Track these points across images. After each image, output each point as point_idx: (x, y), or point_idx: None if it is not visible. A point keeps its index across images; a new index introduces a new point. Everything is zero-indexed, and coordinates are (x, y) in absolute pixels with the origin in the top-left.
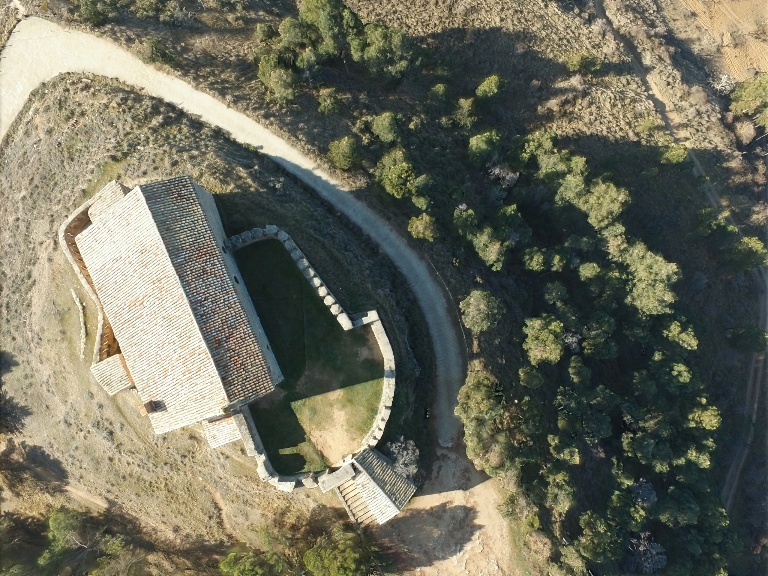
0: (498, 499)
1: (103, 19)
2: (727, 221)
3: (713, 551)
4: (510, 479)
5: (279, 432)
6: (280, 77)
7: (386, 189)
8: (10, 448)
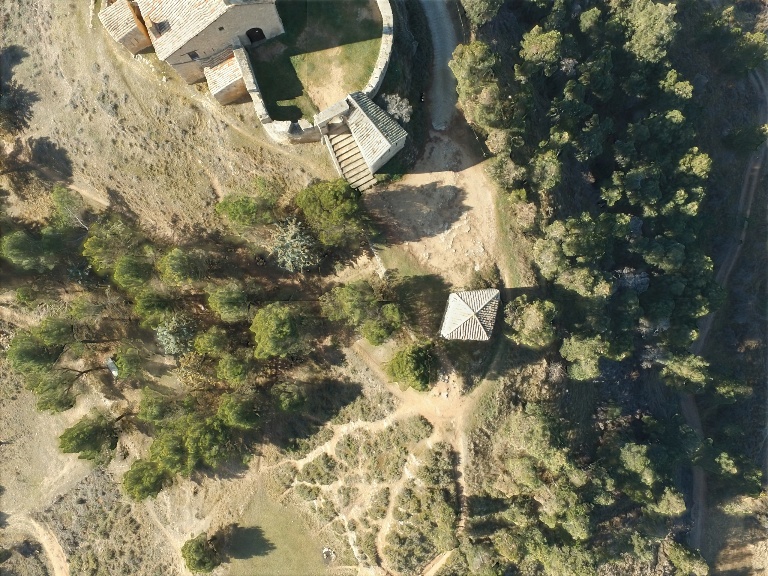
0: (487, 182)
1: None
2: None
3: (696, 294)
4: (499, 136)
5: (278, 85)
6: None
7: None
8: (17, 149)
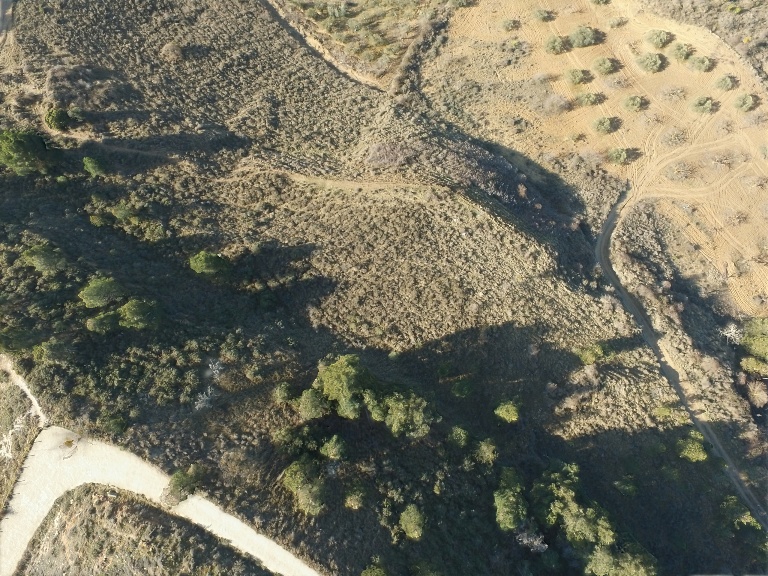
0: None
1: (125, 426)
2: (747, 496)
3: None
4: None
5: None
6: None
7: None
8: None
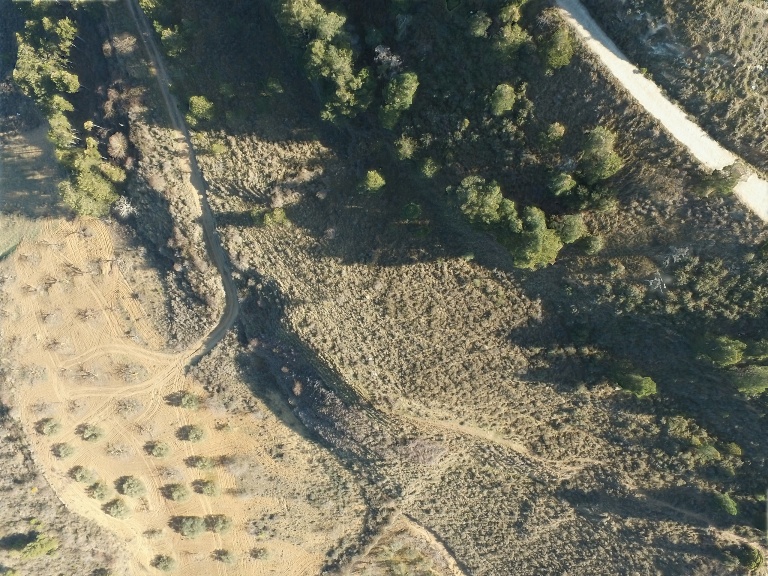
0: None
1: None
2: (154, 52)
3: None
4: None
5: None
6: None
7: None
8: None
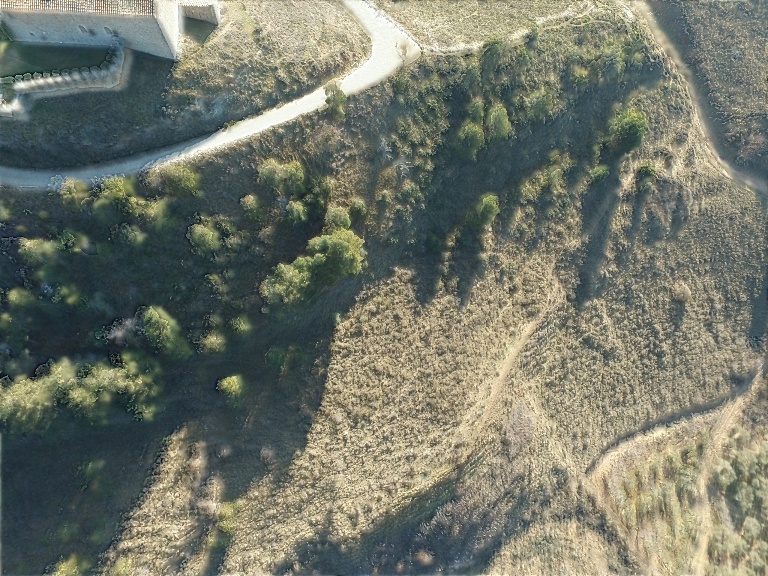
0: None
1: (397, 92)
2: None
3: None
4: None
5: None
6: None
7: None
8: None
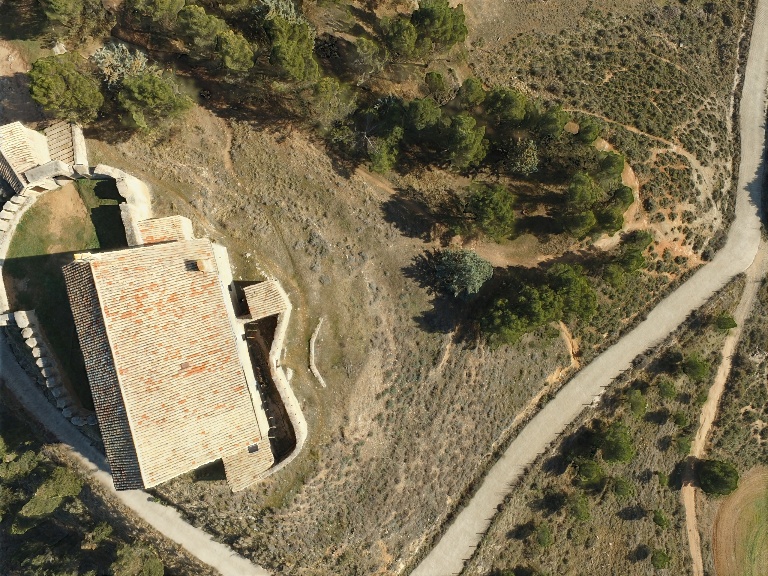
0: None
1: None
2: None
3: None
4: None
5: (116, 221)
6: (121, 569)
7: (3, 441)
8: (448, 237)
